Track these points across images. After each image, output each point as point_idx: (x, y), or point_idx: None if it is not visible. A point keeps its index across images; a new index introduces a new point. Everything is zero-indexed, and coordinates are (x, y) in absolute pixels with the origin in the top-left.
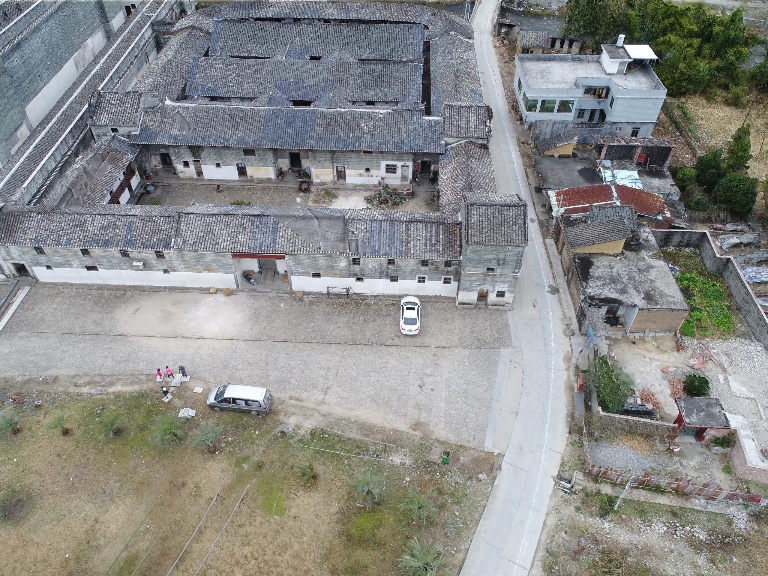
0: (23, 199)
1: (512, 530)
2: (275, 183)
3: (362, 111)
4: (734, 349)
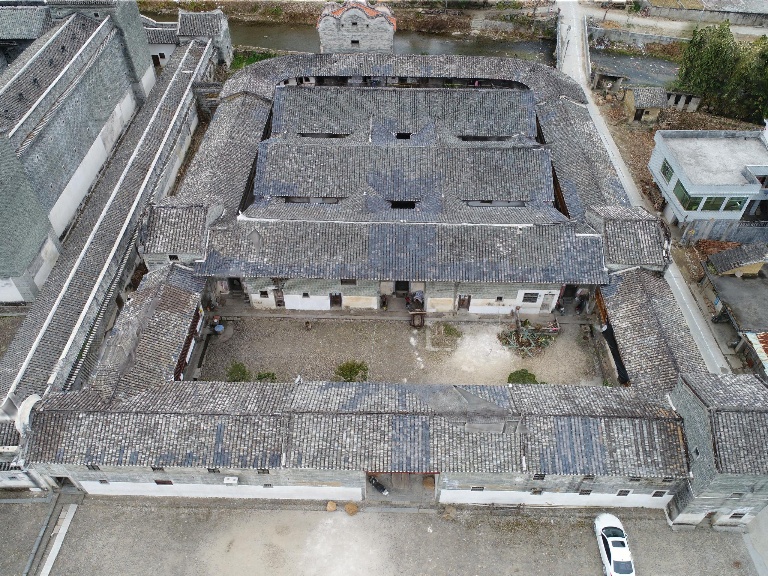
0: (61, 372)
1: None
2: (378, 314)
3: (495, 226)
4: None
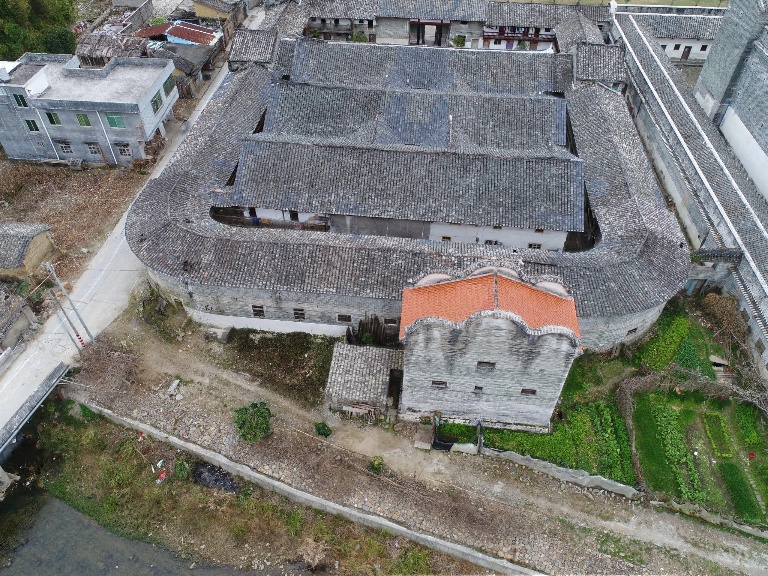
0: None
1: None
2: None
3: (356, 44)
4: (172, 7)
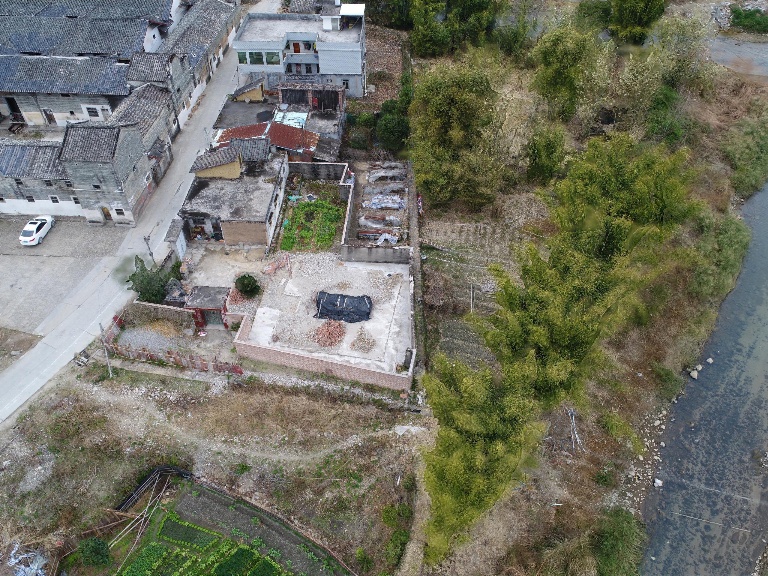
0: None
1: (9, 391)
2: None
3: (62, 58)
4: (309, 258)
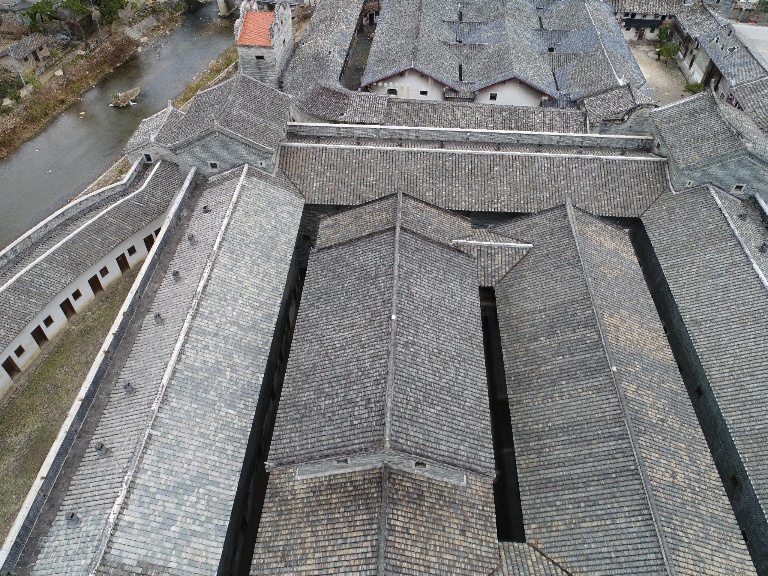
0: None
1: None
2: None
3: None
4: None
